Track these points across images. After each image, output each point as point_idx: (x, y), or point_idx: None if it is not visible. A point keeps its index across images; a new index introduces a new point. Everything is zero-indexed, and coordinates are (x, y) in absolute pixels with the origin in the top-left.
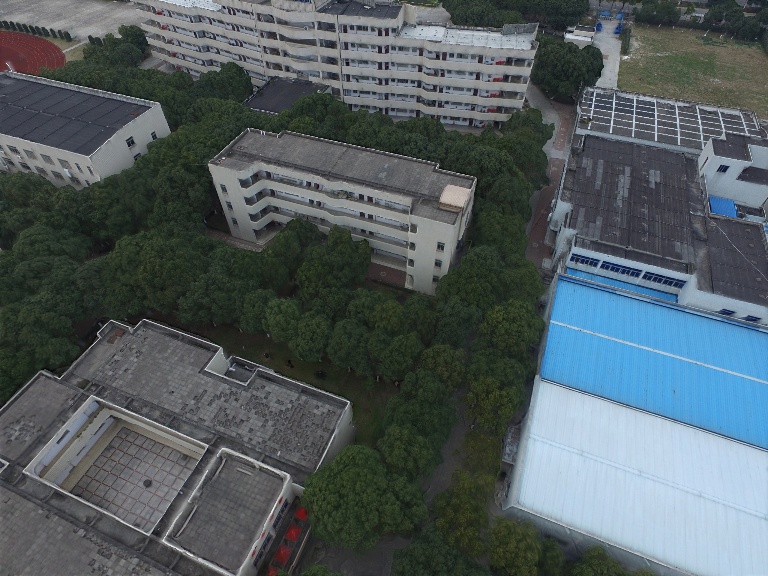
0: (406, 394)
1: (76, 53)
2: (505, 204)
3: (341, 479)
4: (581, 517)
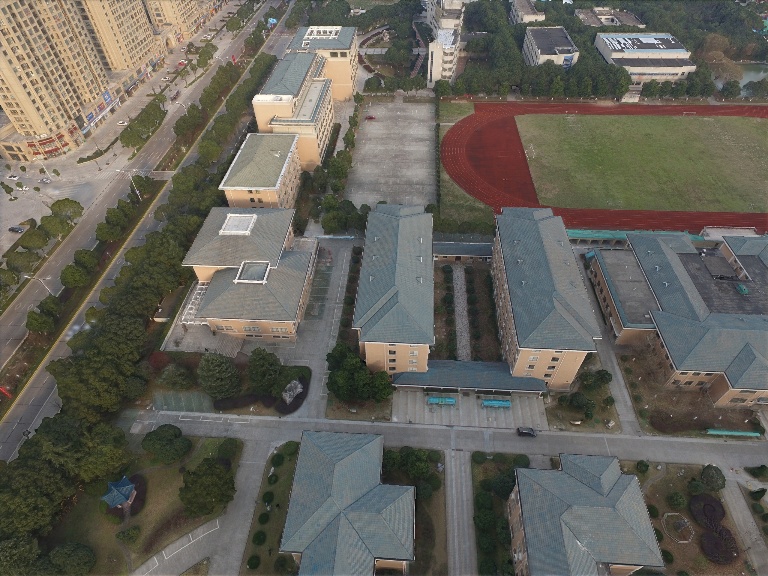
0: (567, 9)
1: (453, 119)
2: (509, 2)
3: (590, 4)
4: (569, 1)
